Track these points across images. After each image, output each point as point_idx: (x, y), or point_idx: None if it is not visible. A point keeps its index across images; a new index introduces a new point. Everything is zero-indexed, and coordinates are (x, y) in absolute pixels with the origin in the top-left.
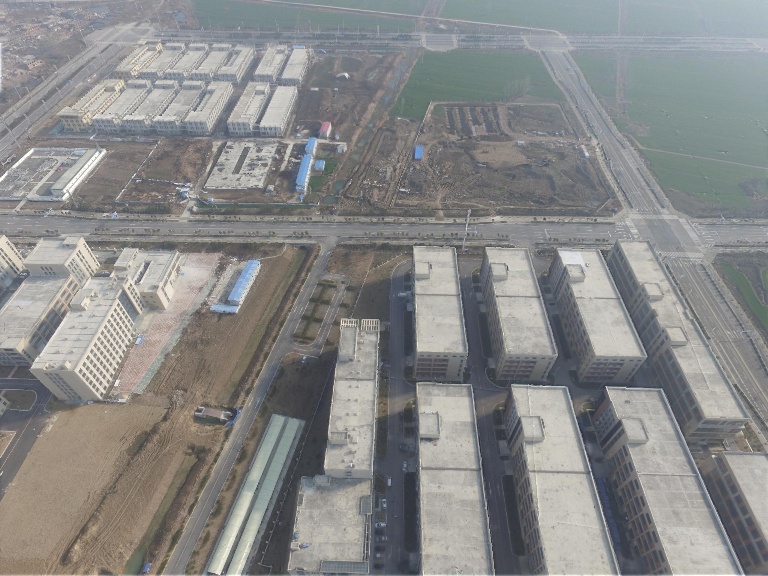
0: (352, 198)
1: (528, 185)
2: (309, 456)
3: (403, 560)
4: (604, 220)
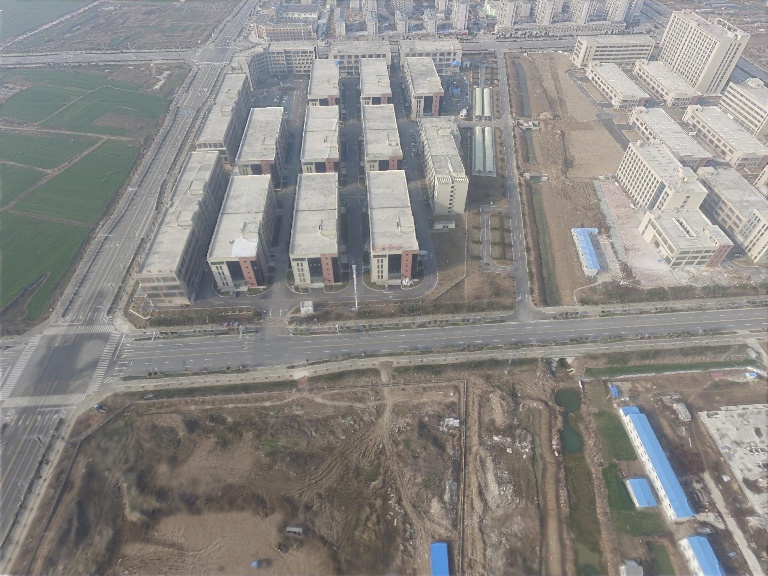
0: (533, 399)
1: (217, 469)
2: (463, 162)
3: (401, 137)
4: (132, 385)
